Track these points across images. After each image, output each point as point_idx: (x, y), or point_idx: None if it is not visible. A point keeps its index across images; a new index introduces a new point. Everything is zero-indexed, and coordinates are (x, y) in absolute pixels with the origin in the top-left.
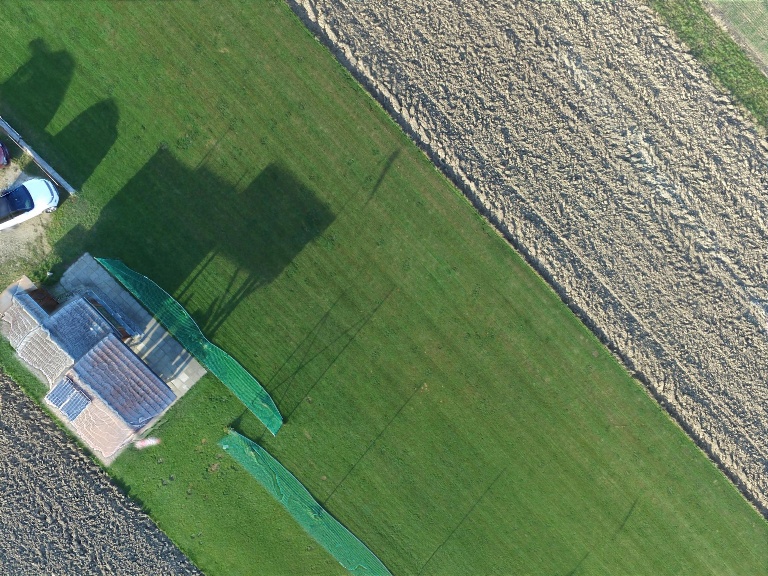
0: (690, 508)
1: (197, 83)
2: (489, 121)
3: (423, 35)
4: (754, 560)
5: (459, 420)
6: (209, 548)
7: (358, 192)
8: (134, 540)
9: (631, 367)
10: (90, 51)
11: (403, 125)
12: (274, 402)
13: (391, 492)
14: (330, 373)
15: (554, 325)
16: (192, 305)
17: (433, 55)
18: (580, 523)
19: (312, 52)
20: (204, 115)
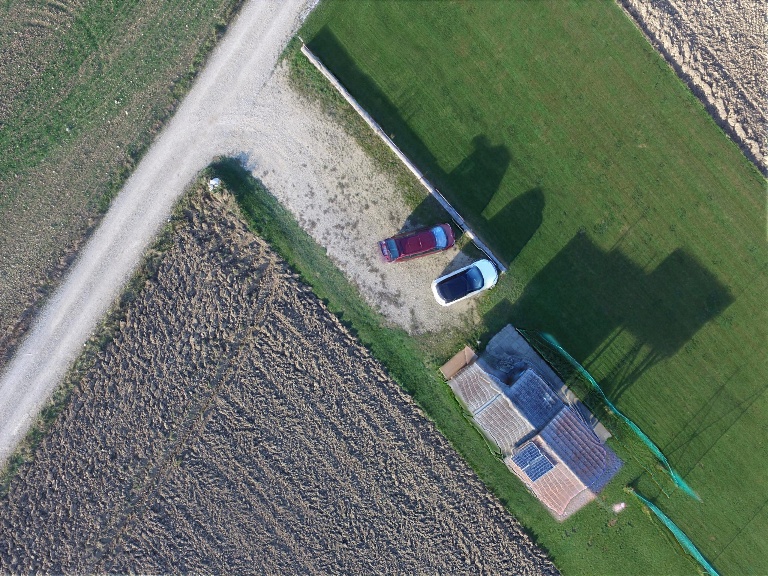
0: None
1: (616, 174)
2: None
3: None
4: None
5: None
6: None
7: (758, 277)
8: None
9: None
10: (524, 145)
11: None
12: (670, 466)
13: None
14: (722, 442)
15: None
16: (599, 374)
17: None
18: None
19: (722, 148)
20: (620, 203)
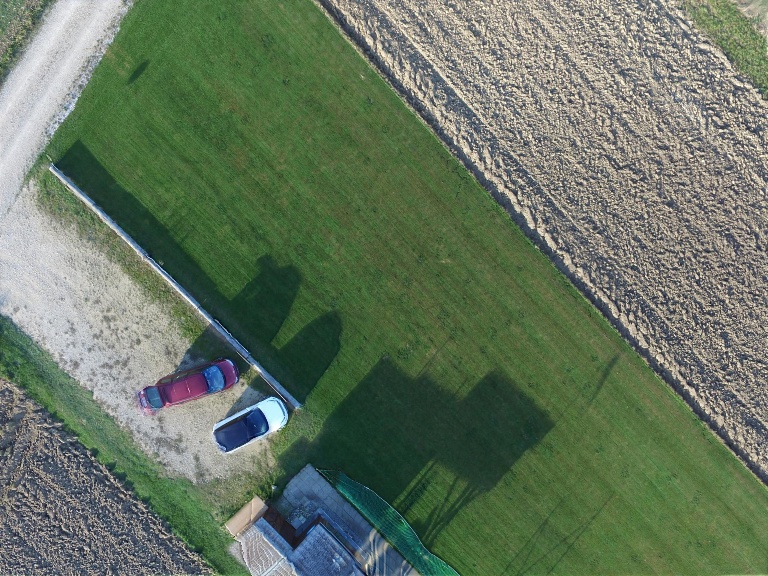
0: None
1: (418, 293)
2: (708, 325)
3: (642, 241)
4: None
5: None
6: None
7: (578, 399)
8: None
9: None
10: (315, 265)
11: (621, 330)
12: None
13: None
14: None
15: None
16: (411, 514)
17: (652, 260)
18: None
19: (532, 260)
20: (425, 325)
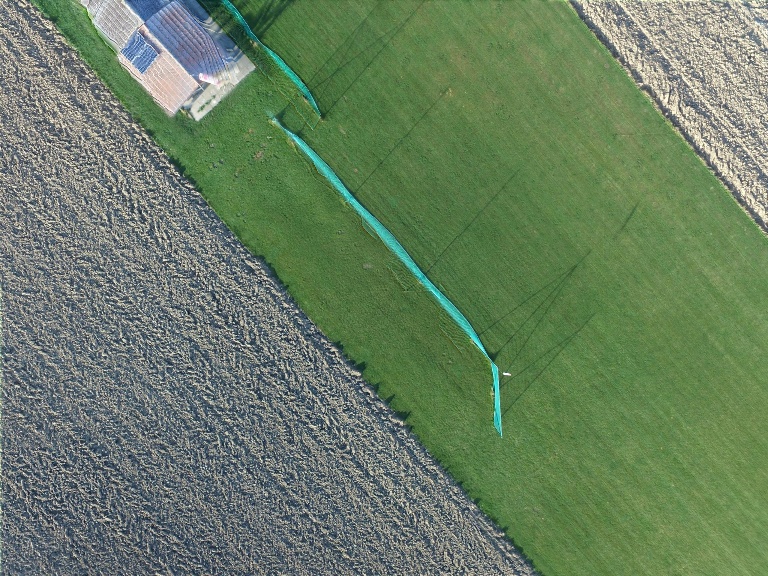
0: (687, 212)
1: None
2: None
3: None
4: (744, 261)
5: (479, 124)
6: (252, 226)
7: None
8: (187, 214)
9: (639, 81)
10: None
11: None
12: (314, 99)
13: (415, 186)
14: (364, 76)
15: (570, 37)
16: (244, 7)
17: None
18: (585, 223)
19: None
20: None
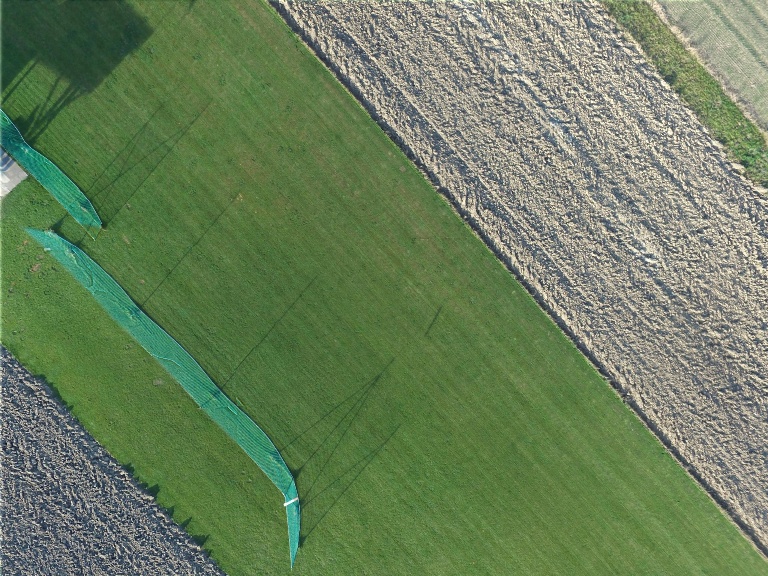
0: (490, 317)
1: None
2: None
3: None
4: (548, 366)
5: (272, 230)
6: (30, 344)
7: (175, 7)
8: None
9: (437, 183)
10: None
11: None
12: (94, 207)
13: (207, 297)
14: (149, 182)
15: (362, 140)
16: (14, 112)
17: None
18: (386, 330)
19: None
20: None
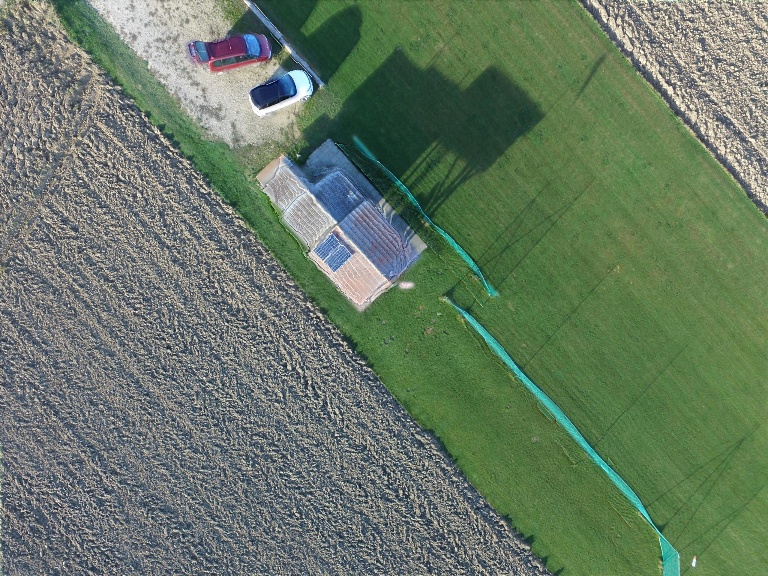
0: None
1: None
2: (688, 31)
3: None
4: None
5: (647, 300)
6: (422, 401)
7: (567, 92)
8: (359, 390)
9: None
10: None
11: (609, 34)
12: (483, 276)
13: (583, 361)
14: (533, 253)
15: (740, 217)
16: (416, 188)
17: None
18: (753, 398)
19: None
20: (435, 21)
